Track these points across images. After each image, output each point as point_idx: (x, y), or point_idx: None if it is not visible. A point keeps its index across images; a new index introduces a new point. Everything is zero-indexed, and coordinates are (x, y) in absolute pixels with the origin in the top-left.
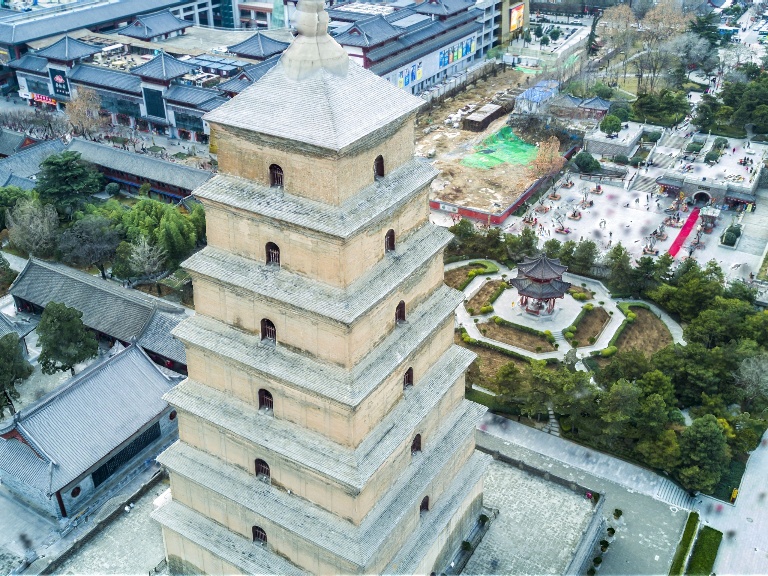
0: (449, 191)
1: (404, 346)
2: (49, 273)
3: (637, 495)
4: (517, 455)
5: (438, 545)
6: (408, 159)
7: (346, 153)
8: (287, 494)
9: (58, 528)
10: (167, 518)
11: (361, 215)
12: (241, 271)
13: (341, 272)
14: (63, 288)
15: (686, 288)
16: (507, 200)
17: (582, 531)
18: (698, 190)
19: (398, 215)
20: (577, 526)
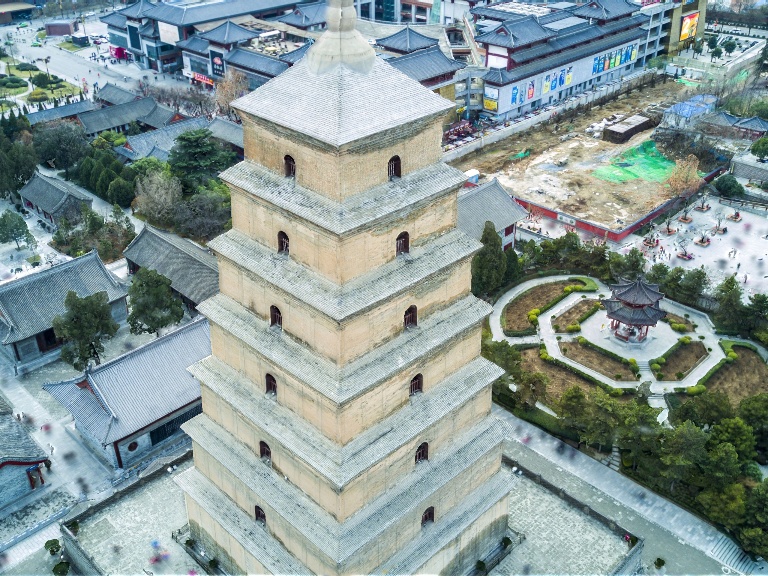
0: (572, 202)
1: (409, 351)
2: (159, 241)
3: (688, 547)
4: (567, 483)
5: (443, 559)
6: (433, 162)
7: (351, 150)
8: (284, 480)
9: (113, 477)
10: (187, 484)
11: (364, 214)
12: (255, 256)
13: (338, 268)
14: (168, 256)
15: None
16: (632, 217)
17: (607, 574)
18: None
19: (414, 218)
20: (606, 567)
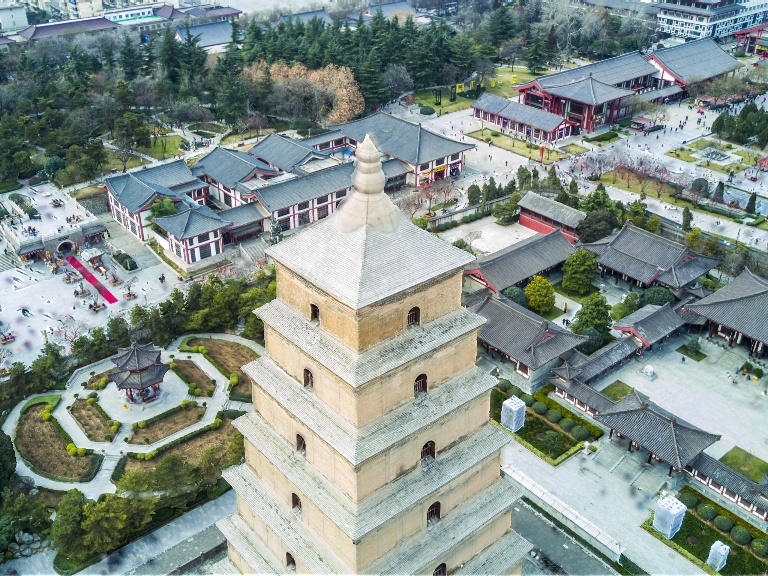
0: None
1: None
2: None
3: None
4: None
5: None
6: None
7: None
8: (461, 570)
9: None
10: None
11: None
12: (407, 420)
13: None
14: None
15: (216, 304)
16: None
17: None
18: (59, 243)
19: None
20: None
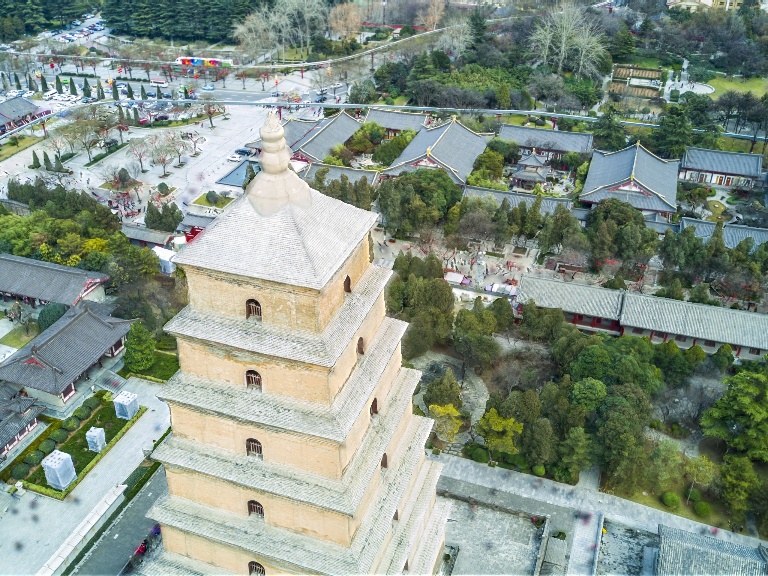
0: None
1: None
2: None
3: None
4: None
5: None
6: None
7: None
8: None
9: None
10: None
11: None
12: None
13: None
14: None
15: None
16: None
17: None
18: None
19: None
20: None
